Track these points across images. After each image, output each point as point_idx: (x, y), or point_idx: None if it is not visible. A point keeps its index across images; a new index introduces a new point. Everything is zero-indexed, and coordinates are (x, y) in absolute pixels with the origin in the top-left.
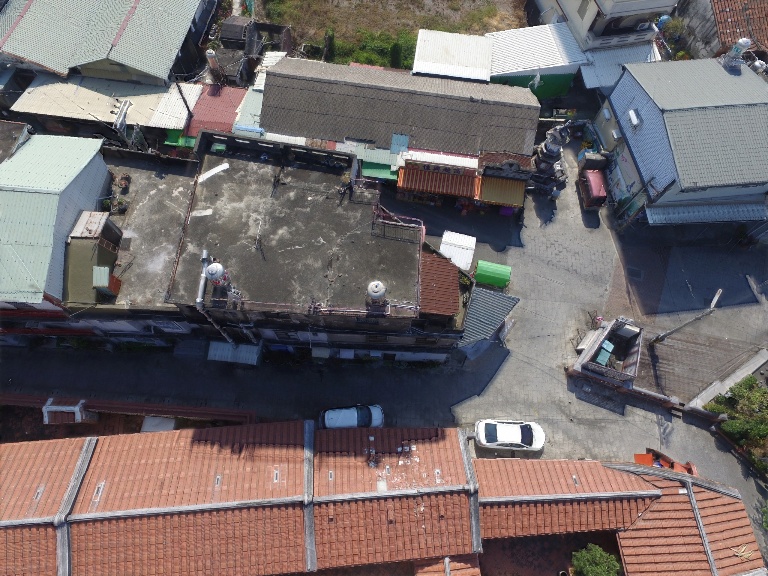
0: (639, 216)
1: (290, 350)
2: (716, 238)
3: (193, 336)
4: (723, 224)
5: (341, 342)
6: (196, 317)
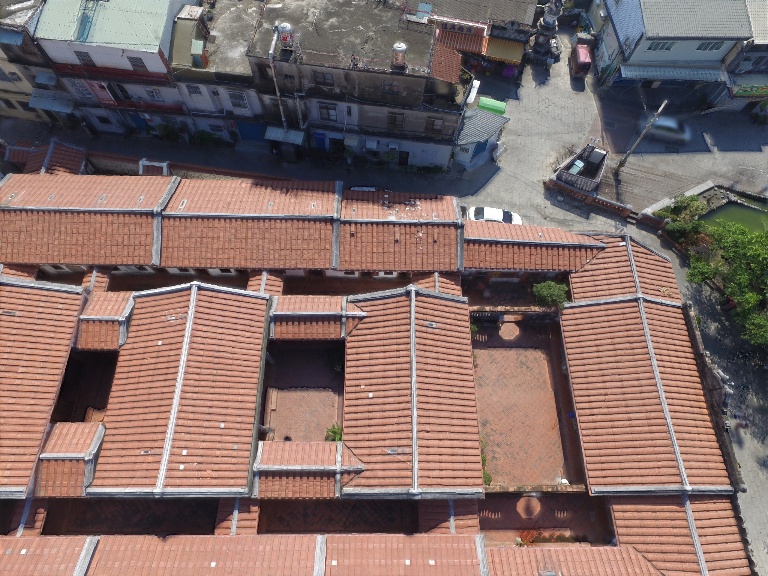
0: (616, 77)
1: (326, 146)
2: (681, 105)
3: (255, 120)
4: (688, 94)
5: (368, 128)
6: (262, 88)
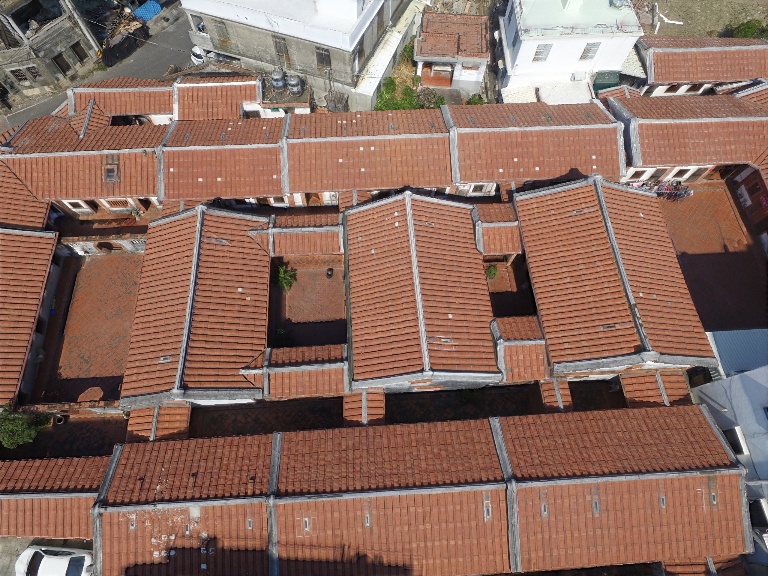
0: None
1: None
2: None
3: None
4: None
5: None
6: None
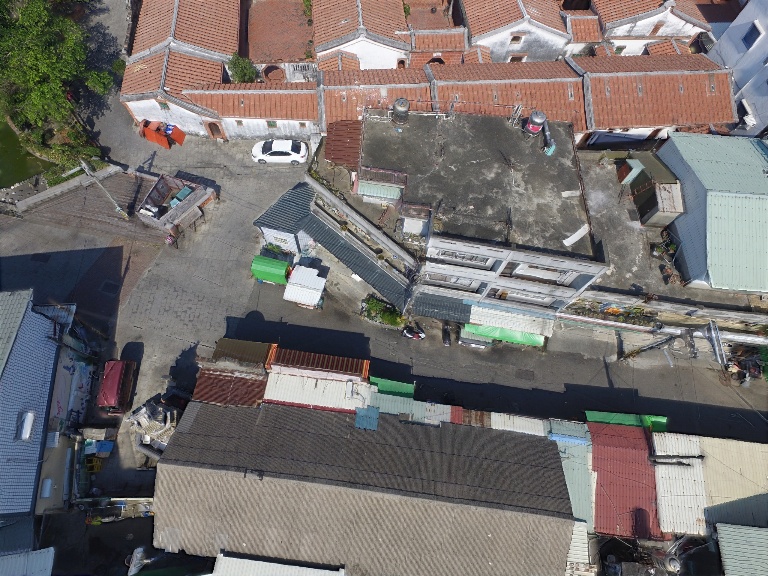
0: None
1: None
2: None
3: None
4: None
5: None
6: None
